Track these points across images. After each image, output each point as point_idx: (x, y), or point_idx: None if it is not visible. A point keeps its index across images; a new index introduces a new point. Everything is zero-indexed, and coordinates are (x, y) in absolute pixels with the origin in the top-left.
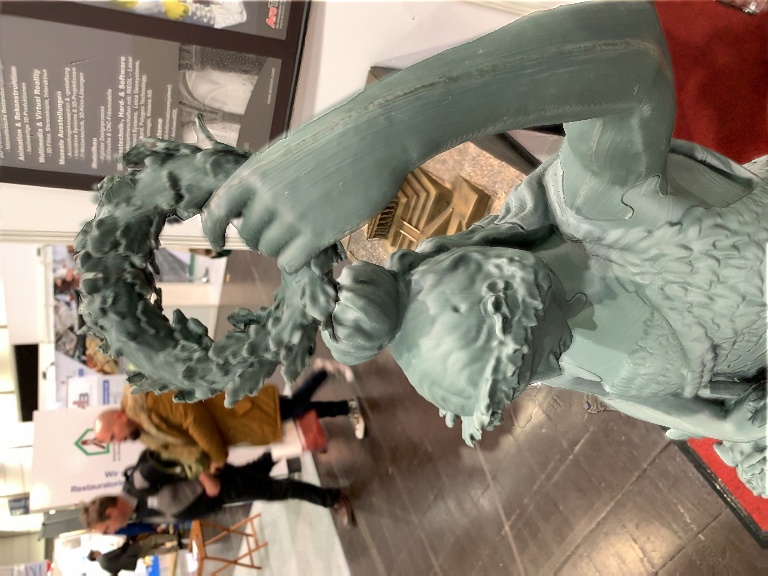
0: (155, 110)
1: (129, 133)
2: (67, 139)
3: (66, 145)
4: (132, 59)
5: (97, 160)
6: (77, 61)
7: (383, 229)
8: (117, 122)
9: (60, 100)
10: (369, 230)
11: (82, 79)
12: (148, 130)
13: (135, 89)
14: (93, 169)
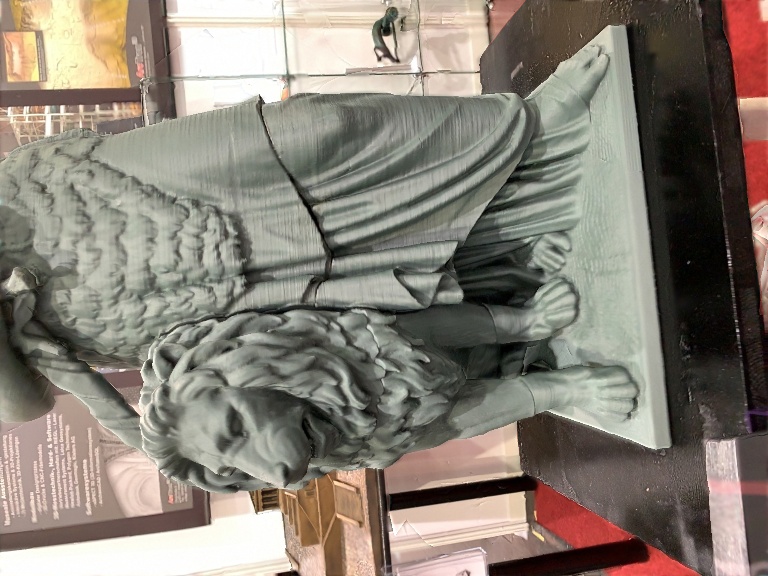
0: (80, 453)
1: (59, 480)
2: (9, 499)
3: (9, 505)
4: (56, 415)
5: (36, 513)
6: (13, 428)
7: (273, 498)
8: (49, 472)
9: (1, 464)
10: (254, 501)
11: (17, 442)
12: (75, 472)
13: (60, 439)
14: (33, 523)
